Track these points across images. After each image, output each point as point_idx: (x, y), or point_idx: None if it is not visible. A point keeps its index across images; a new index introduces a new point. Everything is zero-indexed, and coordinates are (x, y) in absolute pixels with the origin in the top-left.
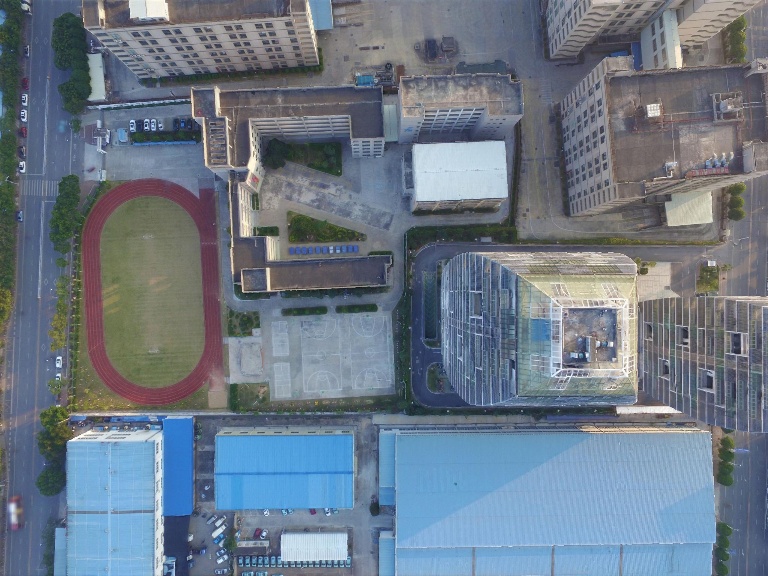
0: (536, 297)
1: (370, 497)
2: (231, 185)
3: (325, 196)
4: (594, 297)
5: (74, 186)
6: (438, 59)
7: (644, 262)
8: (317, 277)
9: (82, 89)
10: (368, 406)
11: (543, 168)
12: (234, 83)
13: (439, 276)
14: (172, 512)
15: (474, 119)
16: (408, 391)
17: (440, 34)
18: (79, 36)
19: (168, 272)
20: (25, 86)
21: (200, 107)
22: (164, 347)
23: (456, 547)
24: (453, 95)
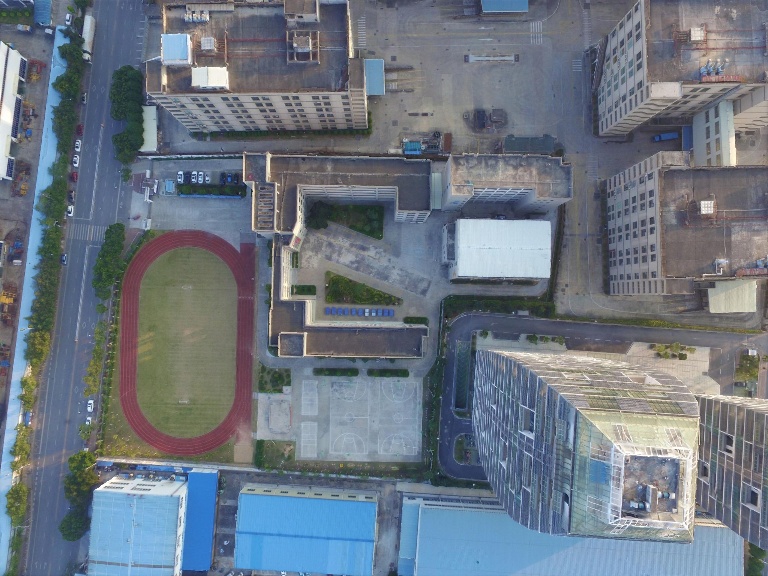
0: (597, 438)
1: (389, 565)
2: (275, 248)
3: (364, 258)
4: (657, 445)
5: (120, 235)
6: (486, 129)
7: (683, 346)
8: (353, 345)
9: (135, 141)
10: (393, 472)
11: (585, 244)
12: (282, 141)
13: (473, 346)
14: (190, 566)
15: (520, 195)
16: (434, 461)
17: (490, 104)
18: (136, 89)
19: (204, 323)
20: (79, 132)
21: (251, 171)
22: (194, 398)
23: None
24: (502, 174)
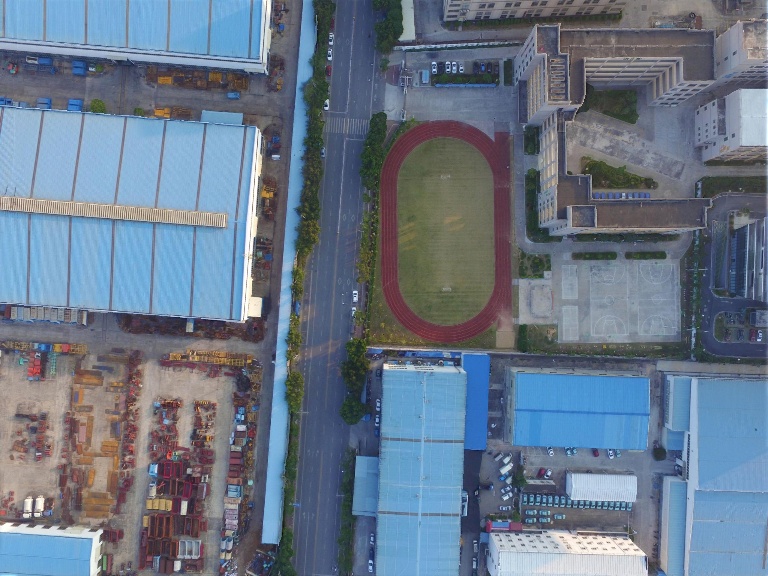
0: None
1: (652, 442)
2: (557, 123)
3: (619, 143)
4: None
5: (385, 123)
6: (735, 11)
7: None
8: (637, 217)
9: (399, 28)
10: (655, 352)
11: None
12: None
13: (731, 226)
14: (468, 446)
15: None
16: None
17: None
18: None
19: (462, 212)
20: (332, 26)
21: (542, 44)
22: (455, 286)
23: (753, 492)
24: None
